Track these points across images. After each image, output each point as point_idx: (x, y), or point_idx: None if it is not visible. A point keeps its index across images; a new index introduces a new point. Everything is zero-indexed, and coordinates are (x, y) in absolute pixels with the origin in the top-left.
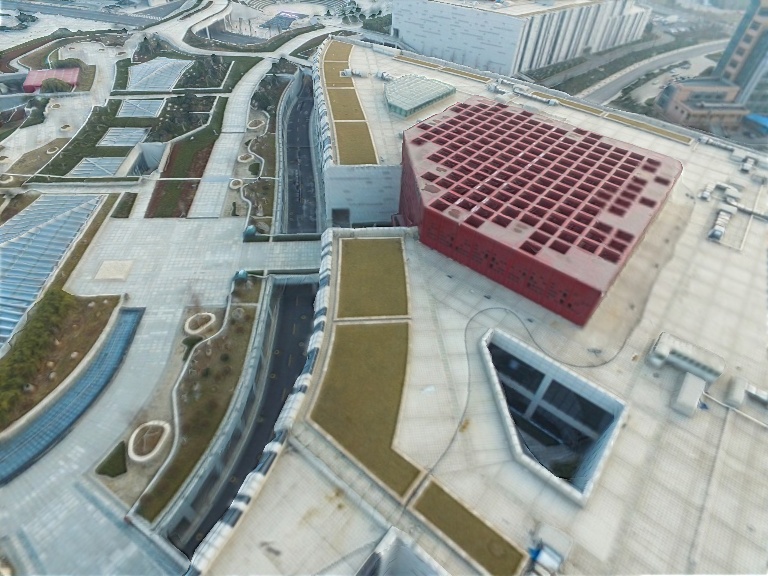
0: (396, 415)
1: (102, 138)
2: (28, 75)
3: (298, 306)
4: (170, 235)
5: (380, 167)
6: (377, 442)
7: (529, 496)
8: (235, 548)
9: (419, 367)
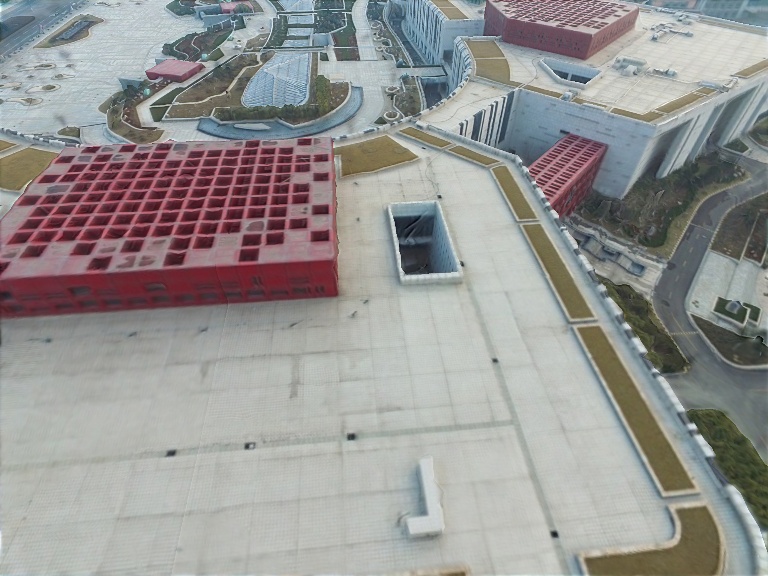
0: (509, 75)
1: (288, 33)
2: (221, 4)
3: (432, 96)
4: (356, 66)
5: (473, 20)
6: (504, 79)
7: (564, 88)
8: (463, 94)
9: (514, 68)
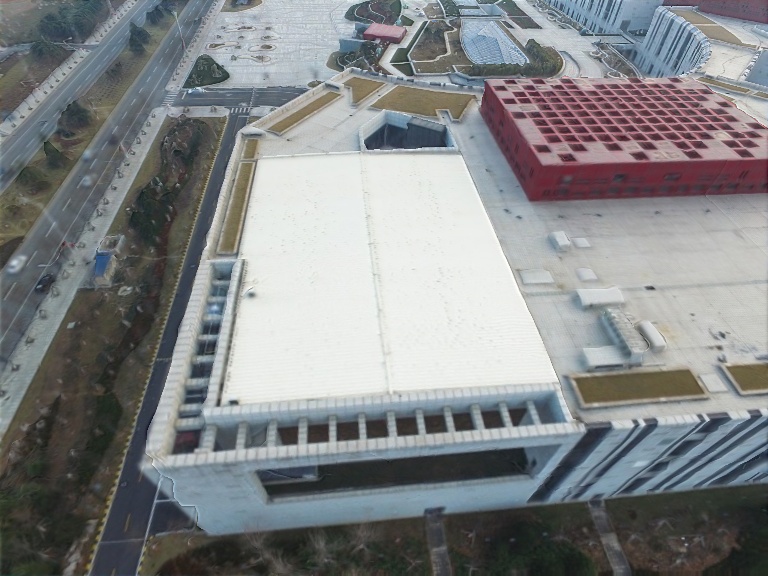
0: None
1: None
2: None
3: None
4: (544, 33)
5: None
6: None
7: None
8: None
9: None
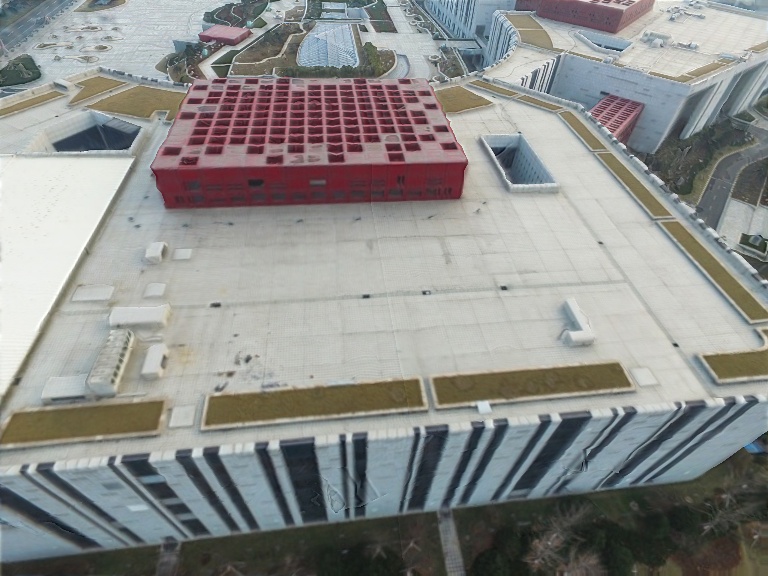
0: None
1: (322, 6)
2: None
3: (467, 67)
4: (395, 37)
5: None
6: None
7: (603, 55)
8: None
9: (554, 38)
